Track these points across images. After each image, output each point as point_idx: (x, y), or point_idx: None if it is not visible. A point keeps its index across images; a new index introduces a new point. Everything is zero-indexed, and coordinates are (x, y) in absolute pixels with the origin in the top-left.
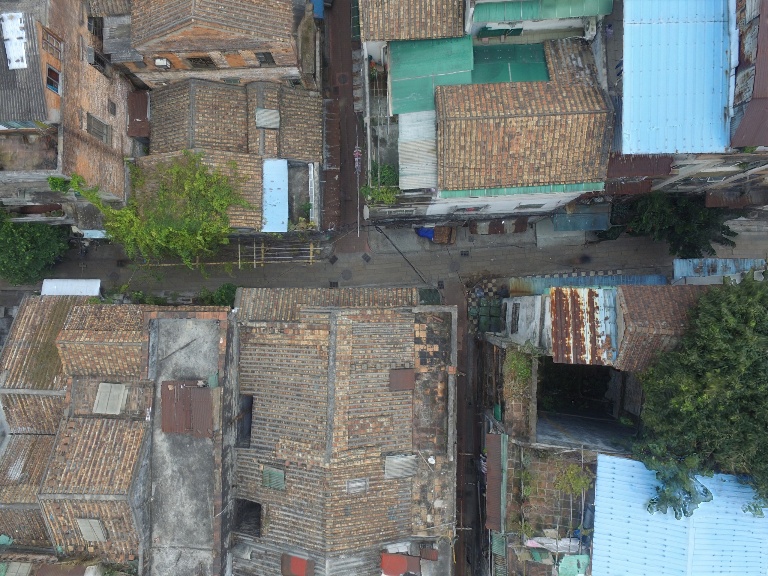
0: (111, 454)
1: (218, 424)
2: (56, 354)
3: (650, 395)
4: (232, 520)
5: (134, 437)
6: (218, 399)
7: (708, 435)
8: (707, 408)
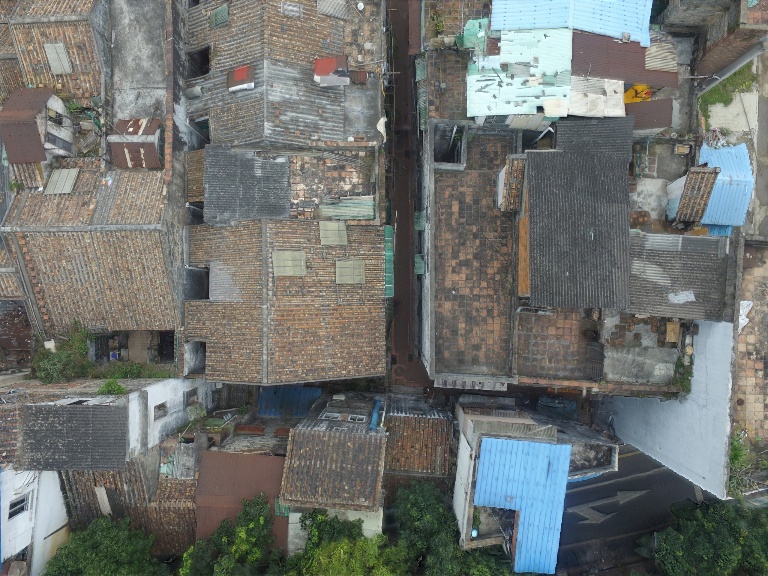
0: None
1: None
2: None
3: None
4: (186, 76)
5: None
6: None
7: None
8: None
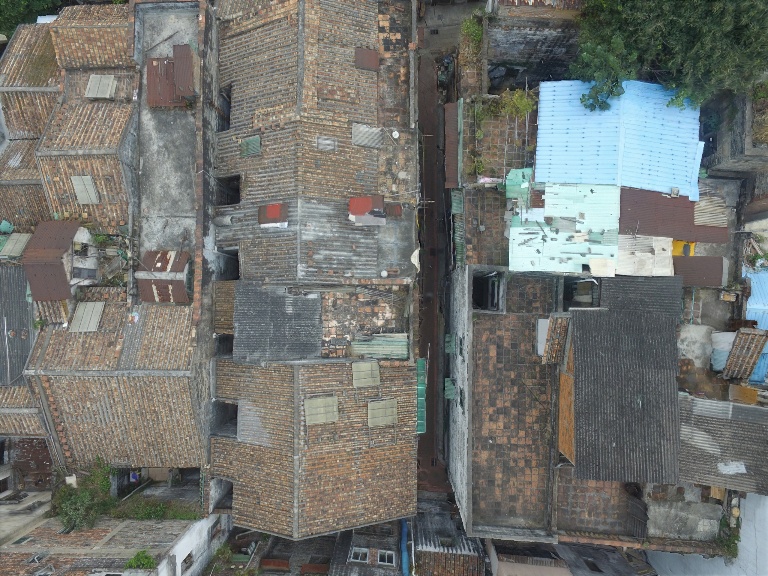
0: (102, 125)
1: (199, 90)
2: (50, 63)
3: (586, 25)
4: (214, 201)
5: (122, 113)
6: (198, 66)
7: (632, 24)
8: (631, 1)
